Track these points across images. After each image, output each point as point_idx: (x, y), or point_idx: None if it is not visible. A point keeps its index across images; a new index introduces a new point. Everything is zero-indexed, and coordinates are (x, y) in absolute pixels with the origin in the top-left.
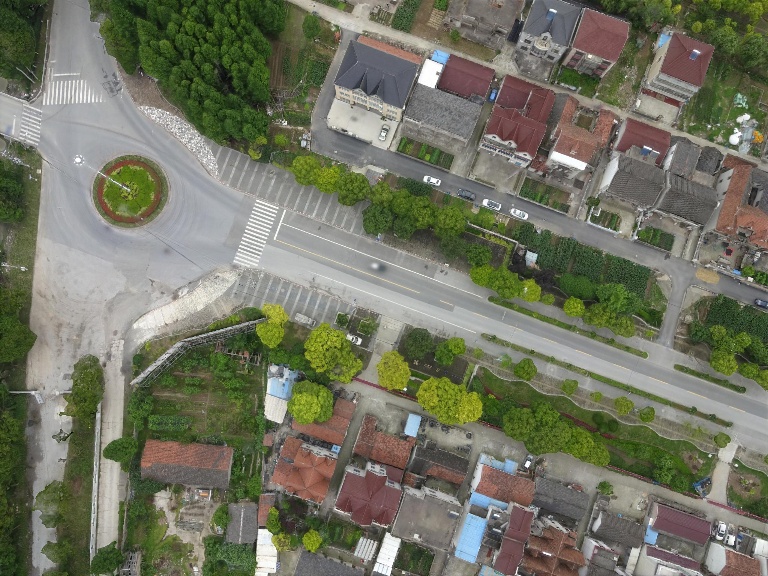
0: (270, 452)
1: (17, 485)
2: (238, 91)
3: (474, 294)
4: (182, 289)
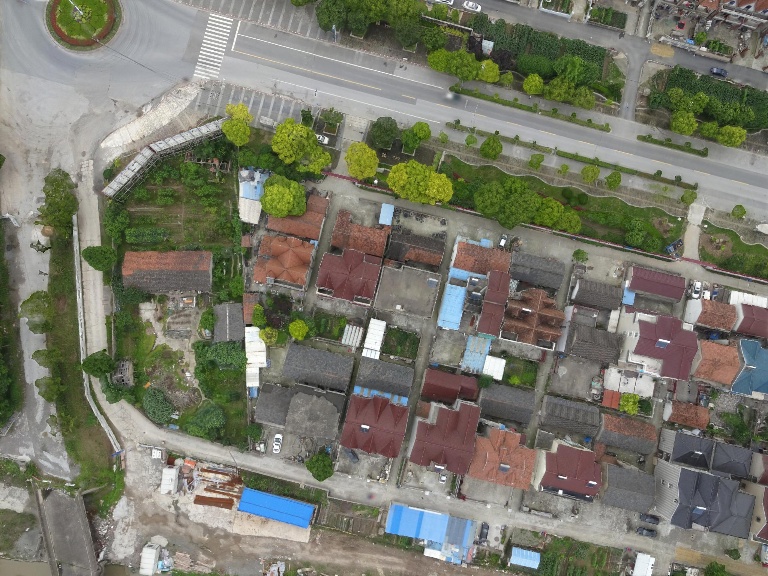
0: (249, 254)
1: (2, 307)
2: None
3: (435, 86)
4: (145, 106)
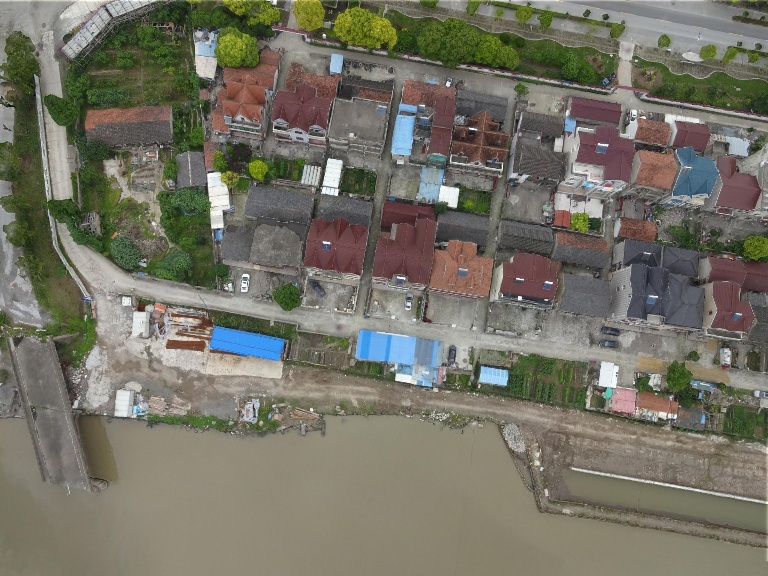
0: (207, 107)
1: None
2: None
3: None
4: None
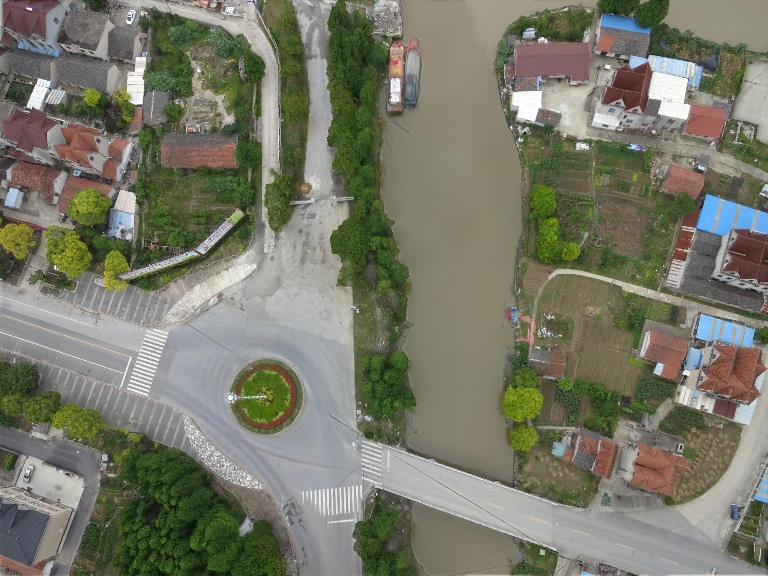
0: None
1: None
2: (143, 503)
3: None
4: (215, 304)
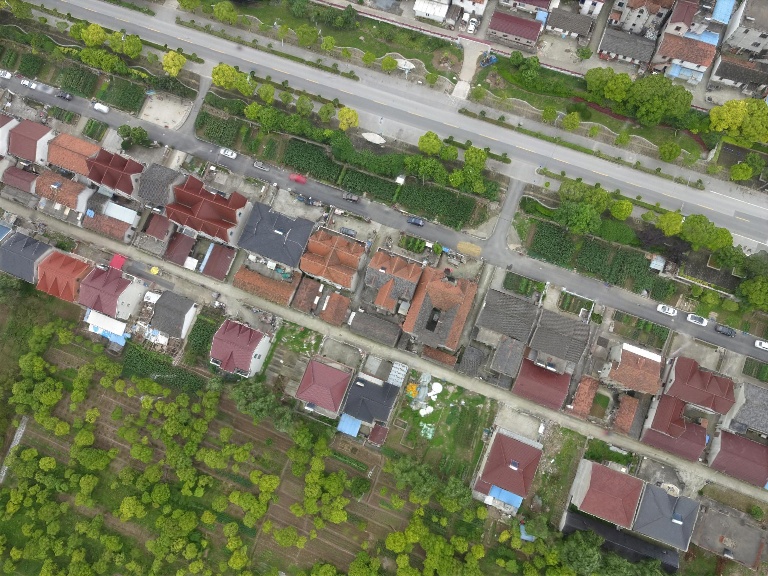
0: None
1: None
2: None
3: None
4: None
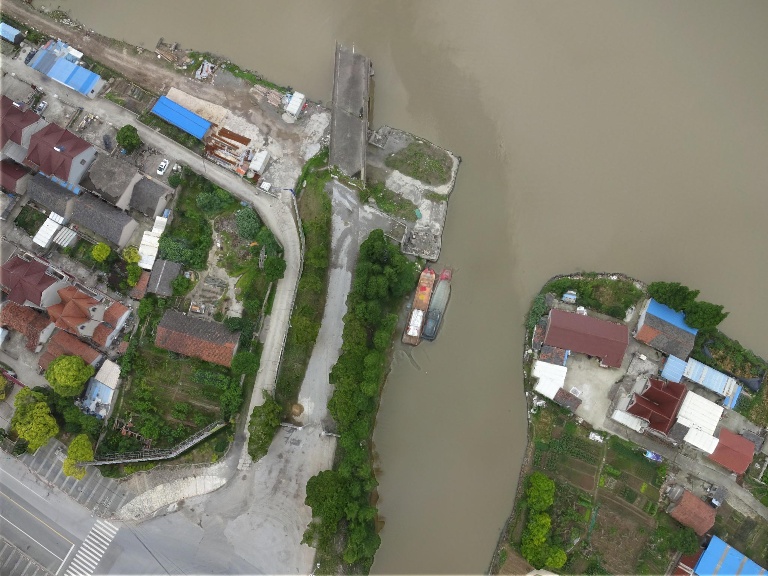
0: None
1: None
2: None
3: None
4: (173, 510)
